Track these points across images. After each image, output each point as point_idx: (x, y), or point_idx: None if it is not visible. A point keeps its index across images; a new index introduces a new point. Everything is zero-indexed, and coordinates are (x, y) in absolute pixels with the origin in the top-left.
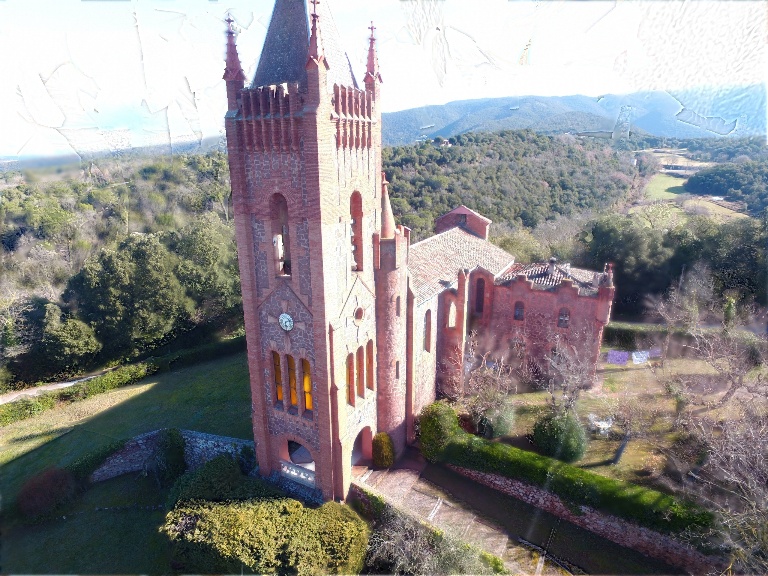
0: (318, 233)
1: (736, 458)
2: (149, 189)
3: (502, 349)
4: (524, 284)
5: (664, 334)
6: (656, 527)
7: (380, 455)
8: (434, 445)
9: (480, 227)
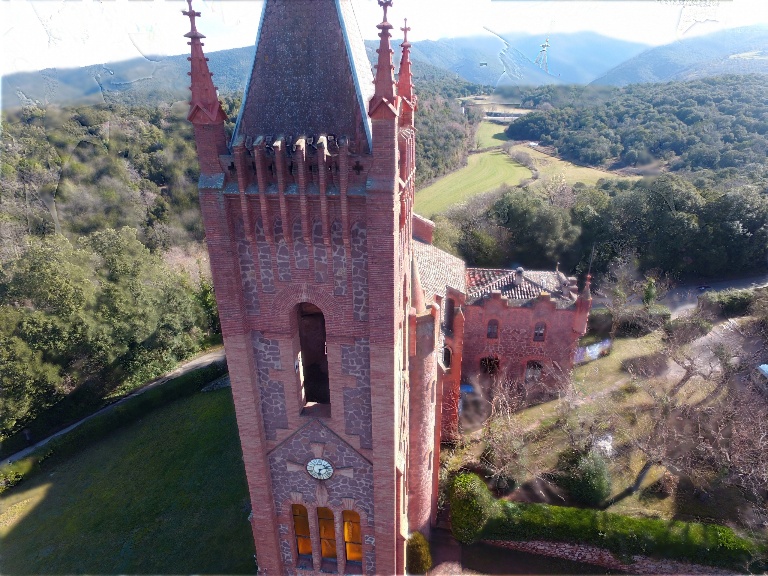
0: (388, 362)
1: (767, 480)
2: None
3: (474, 369)
4: (498, 301)
5: (598, 318)
6: (707, 561)
7: (419, 562)
8: (472, 528)
9: (425, 231)
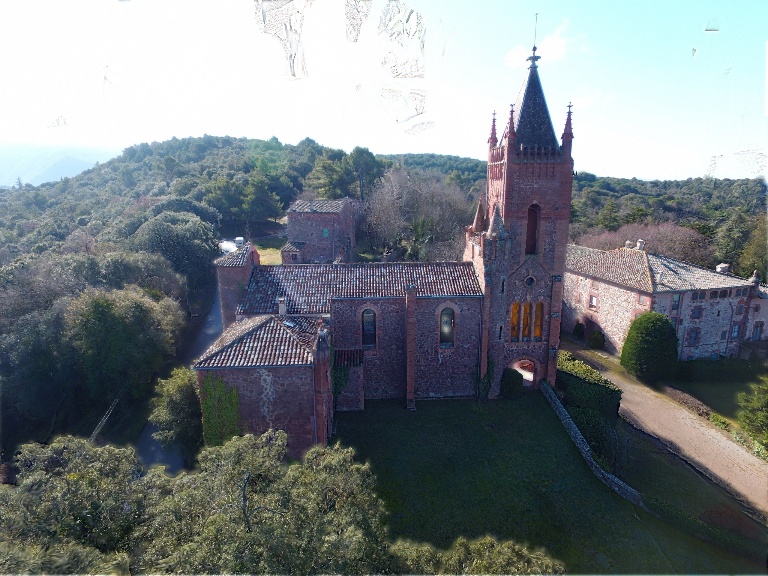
0: None
1: None
2: None
3: None
4: None
5: None
6: None
7: None
8: None
9: None
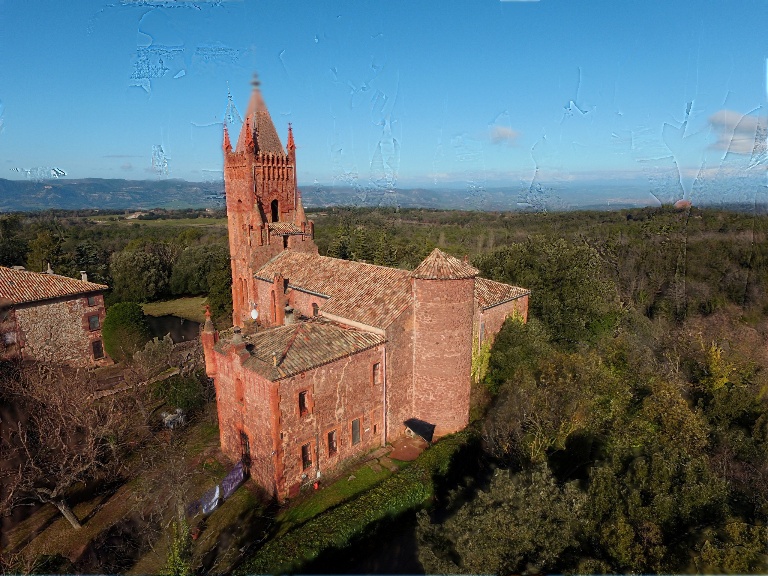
0: None
1: None
2: (724, 221)
3: None
4: None
5: None
6: None
7: None
8: None
9: None
